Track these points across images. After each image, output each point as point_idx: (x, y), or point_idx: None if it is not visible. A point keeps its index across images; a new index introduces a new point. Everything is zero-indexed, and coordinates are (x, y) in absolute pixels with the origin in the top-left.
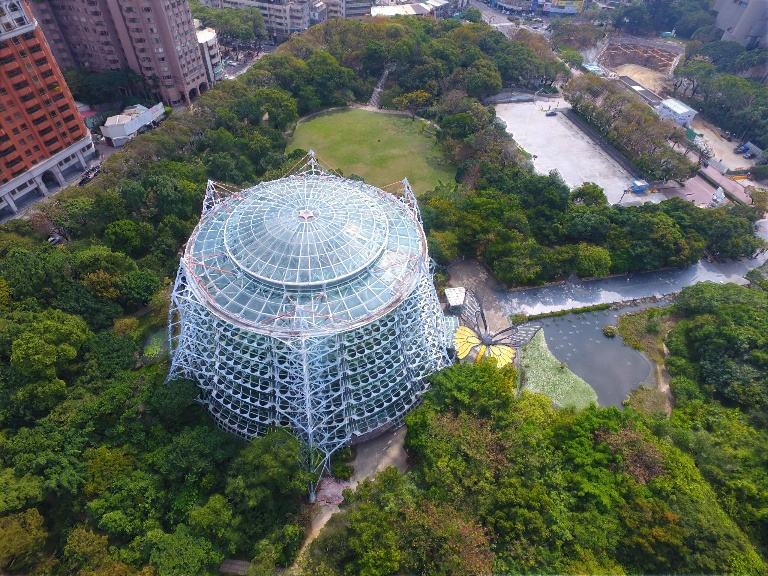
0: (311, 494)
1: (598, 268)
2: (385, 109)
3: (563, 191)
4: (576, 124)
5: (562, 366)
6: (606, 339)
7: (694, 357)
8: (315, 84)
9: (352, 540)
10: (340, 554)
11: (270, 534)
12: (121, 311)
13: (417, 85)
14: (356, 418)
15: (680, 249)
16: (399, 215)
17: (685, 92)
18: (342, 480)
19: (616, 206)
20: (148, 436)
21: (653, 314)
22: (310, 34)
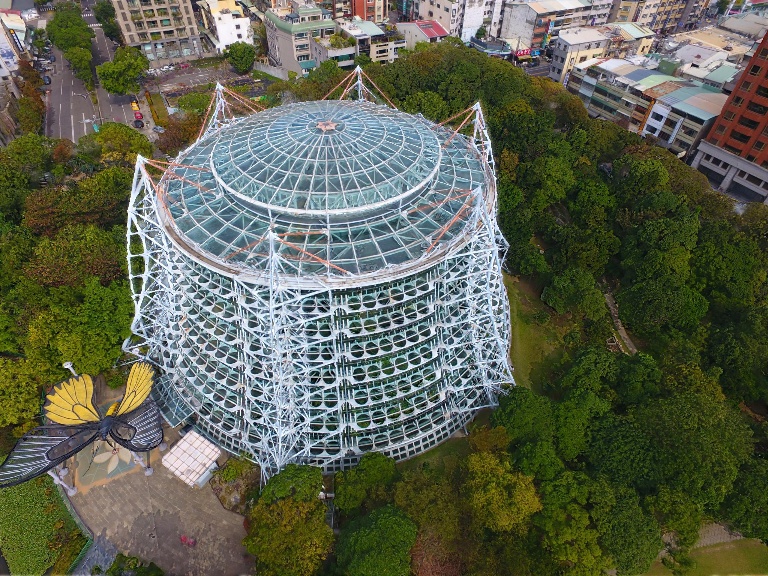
0: None
1: None
2: None
3: None
4: None
5: None
6: None
7: None
8: None
9: None
10: None
11: None
12: None
13: None
14: None
15: None
16: (262, 254)
17: None
18: None
19: None
20: None
21: None
22: None
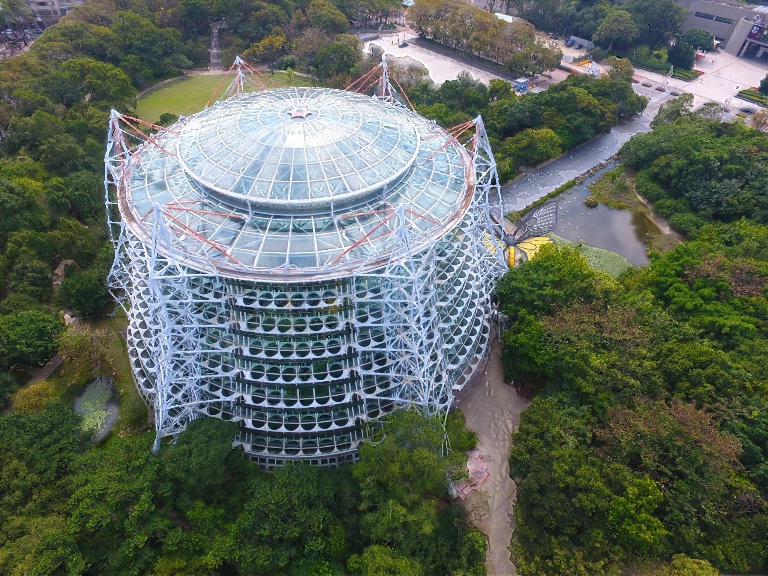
0: (450, 486)
1: (552, 148)
2: (233, 70)
3: (481, 90)
4: (431, 49)
5: (581, 243)
6: (592, 210)
7: (673, 195)
8: (136, 51)
9: (583, 497)
10: (574, 525)
11: (456, 560)
12: (11, 381)
13: (262, 34)
14: (454, 367)
15: (601, 115)
16: None
17: (501, 8)
18: (469, 452)
19: (529, 94)
20: (185, 531)
21: (615, 175)
22: (96, 2)
